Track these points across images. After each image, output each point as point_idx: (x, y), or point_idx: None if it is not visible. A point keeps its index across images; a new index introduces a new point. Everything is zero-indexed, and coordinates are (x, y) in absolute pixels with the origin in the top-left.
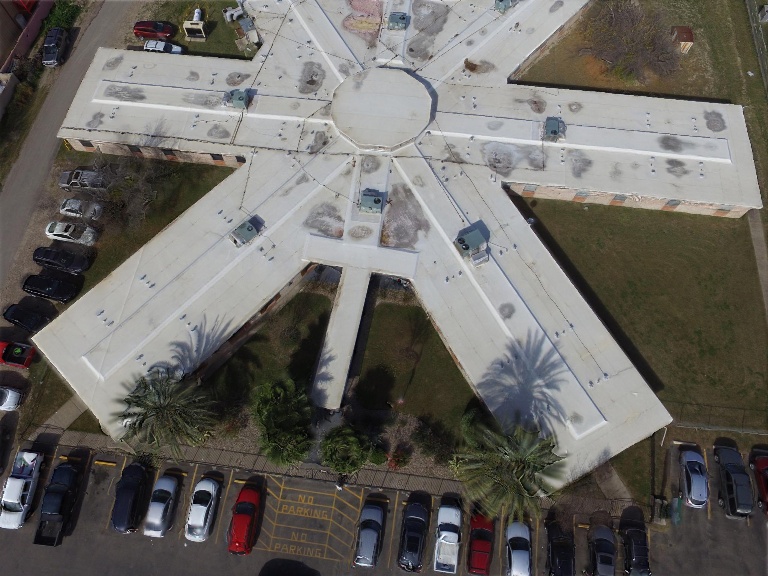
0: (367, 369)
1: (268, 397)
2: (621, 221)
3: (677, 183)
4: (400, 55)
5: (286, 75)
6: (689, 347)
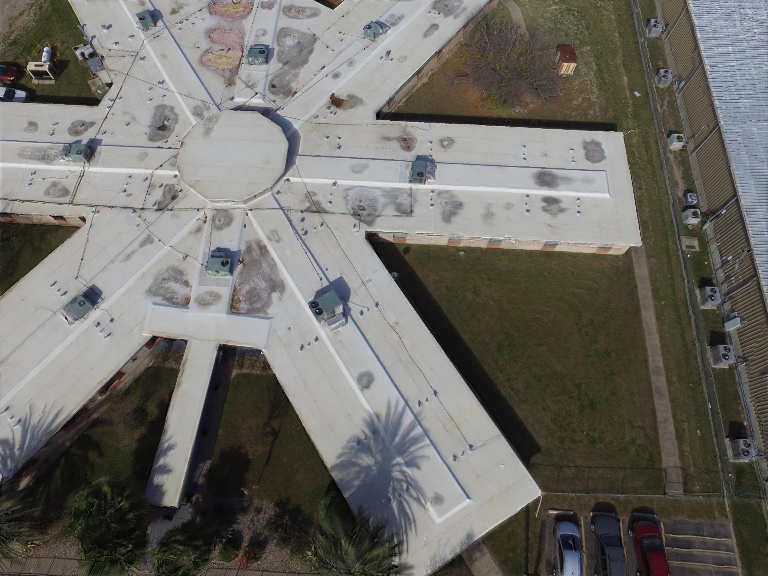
0: (220, 451)
1: (81, 509)
2: (499, 265)
3: (552, 223)
4: (260, 93)
5: (135, 121)
6: (568, 402)
